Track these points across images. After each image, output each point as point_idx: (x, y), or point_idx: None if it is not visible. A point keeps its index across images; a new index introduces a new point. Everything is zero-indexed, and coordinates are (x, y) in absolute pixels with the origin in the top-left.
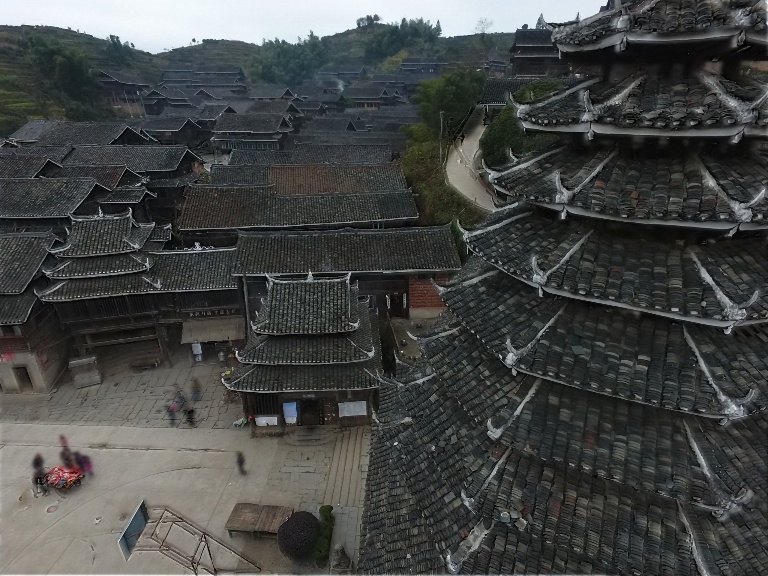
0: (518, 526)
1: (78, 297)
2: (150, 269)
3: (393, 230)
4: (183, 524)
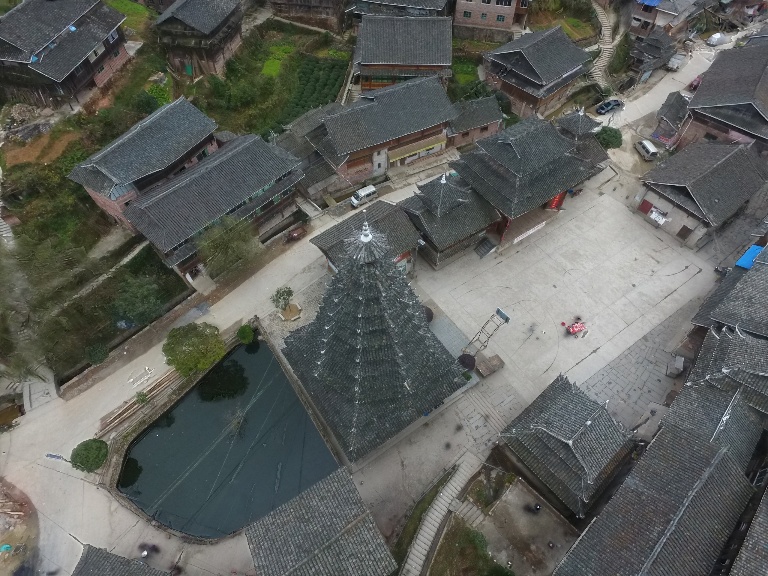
0: None
1: None
2: None
3: (645, 568)
4: None
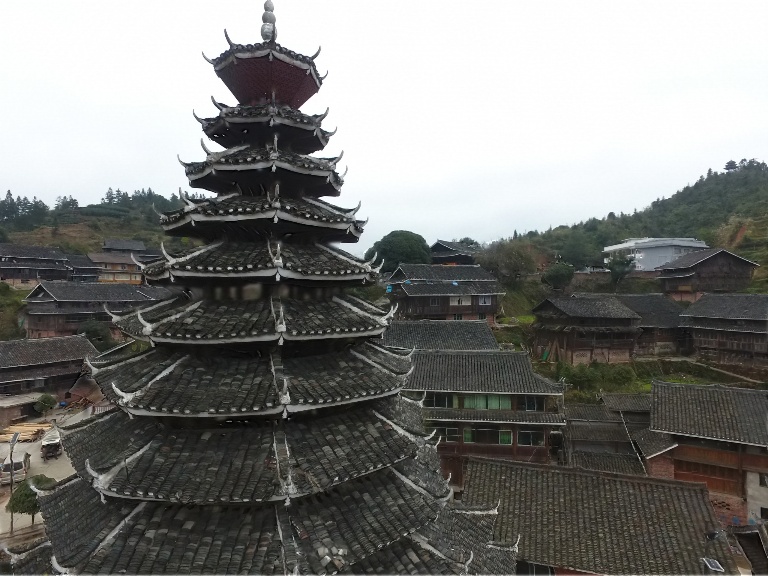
0: None
1: None
2: None
3: None
4: None
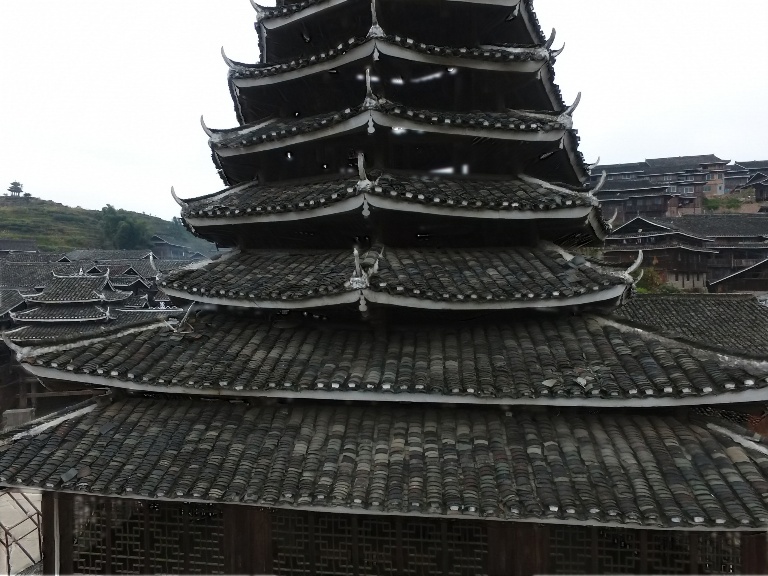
0: (216, 209)
1: (33, 338)
2: (111, 321)
3: None
4: (18, 496)
